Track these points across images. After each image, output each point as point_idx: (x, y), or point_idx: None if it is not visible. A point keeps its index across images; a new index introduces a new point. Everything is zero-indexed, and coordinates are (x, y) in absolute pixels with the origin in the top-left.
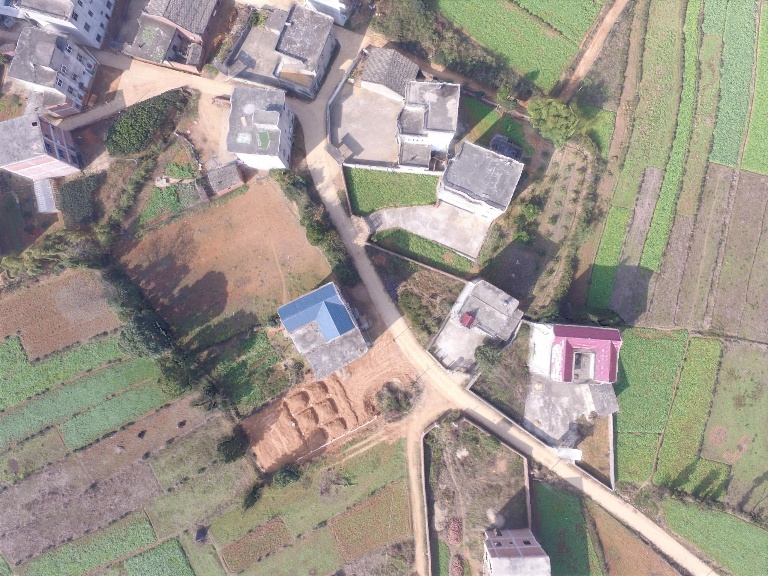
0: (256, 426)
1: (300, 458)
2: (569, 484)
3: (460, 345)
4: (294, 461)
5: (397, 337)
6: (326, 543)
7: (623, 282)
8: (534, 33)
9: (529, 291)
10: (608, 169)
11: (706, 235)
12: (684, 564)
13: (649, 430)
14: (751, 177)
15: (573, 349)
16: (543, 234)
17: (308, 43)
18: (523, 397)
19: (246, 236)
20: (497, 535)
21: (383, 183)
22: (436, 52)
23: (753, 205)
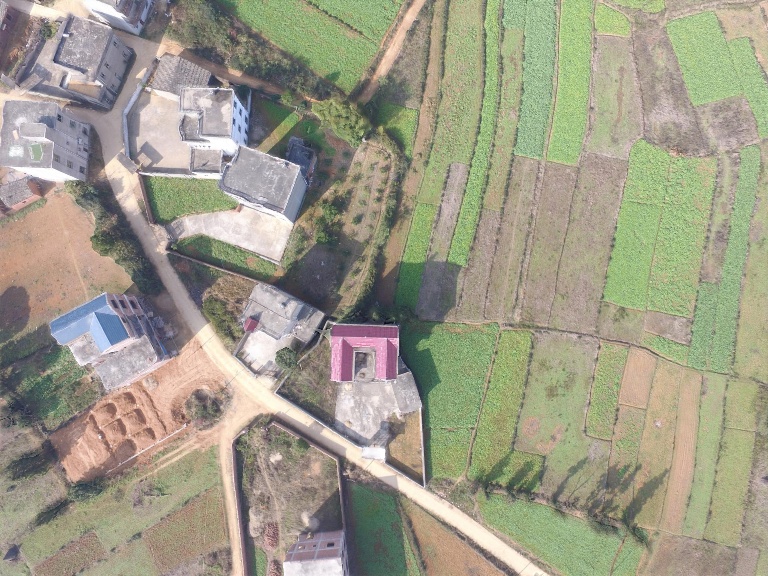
0: (63, 441)
1: (109, 471)
2: (383, 483)
3: (268, 349)
4: (104, 474)
5: (204, 344)
6: (141, 555)
7: (431, 278)
8: (334, 34)
9: (328, 292)
10: (413, 166)
11: (514, 228)
12: (502, 557)
13: (461, 425)
14: (557, 168)
15: (353, 348)
16: (348, 234)
17: (88, 54)
18: (333, 398)
19: (46, 249)
20: (308, 538)
21: (183, 190)
22: (232, 57)
23: (559, 196)
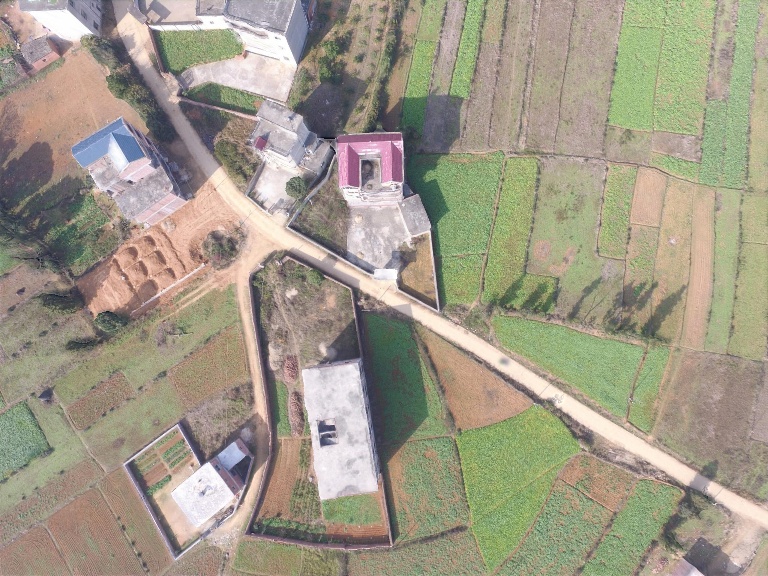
0: (89, 284)
1: (134, 311)
2: (398, 312)
3: (279, 188)
4: (129, 315)
5: (217, 186)
6: (167, 393)
7: (434, 112)
8: None
9: (334, 123)
10: (410, 6)
11: (513, 59)
12: (520, 380)
13: (472, 251)
14: None
15: (359, 156)
16: (350, 73)
17: None
18: (344, 231)
19: (66, 106)
20: (326, 364)
21: (191, 41)
22: None
23: (558, 25)
